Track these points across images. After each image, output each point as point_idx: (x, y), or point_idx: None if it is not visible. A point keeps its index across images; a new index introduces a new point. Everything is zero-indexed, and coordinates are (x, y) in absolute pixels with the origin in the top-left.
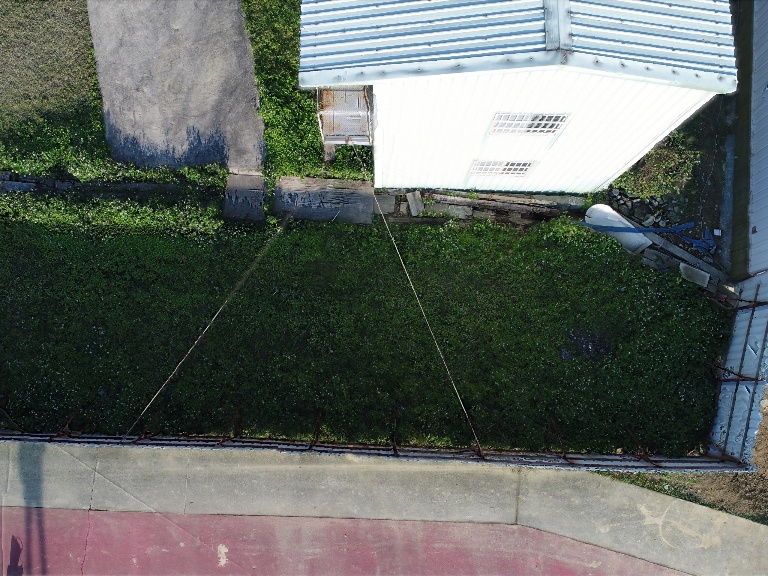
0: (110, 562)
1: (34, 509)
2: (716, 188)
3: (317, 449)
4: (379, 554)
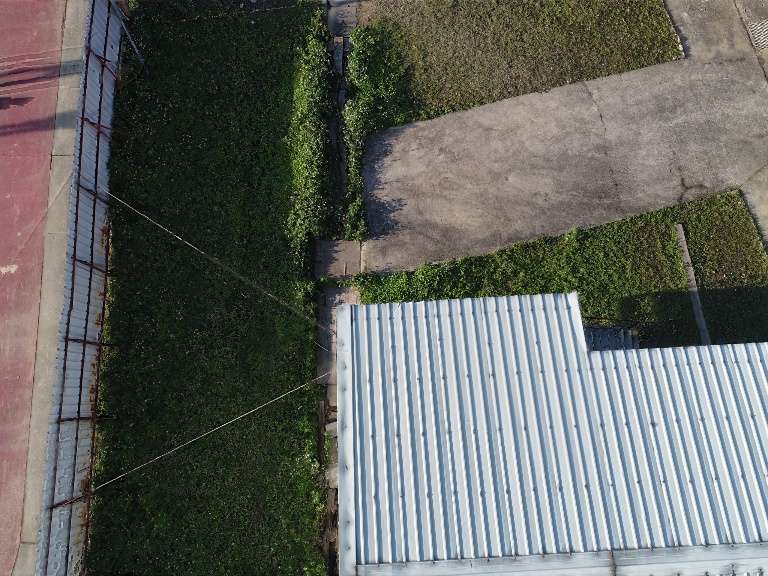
0: (8, 177)
1: (55, 111)
2: None
3: (69, 346)
4: (1, 409)
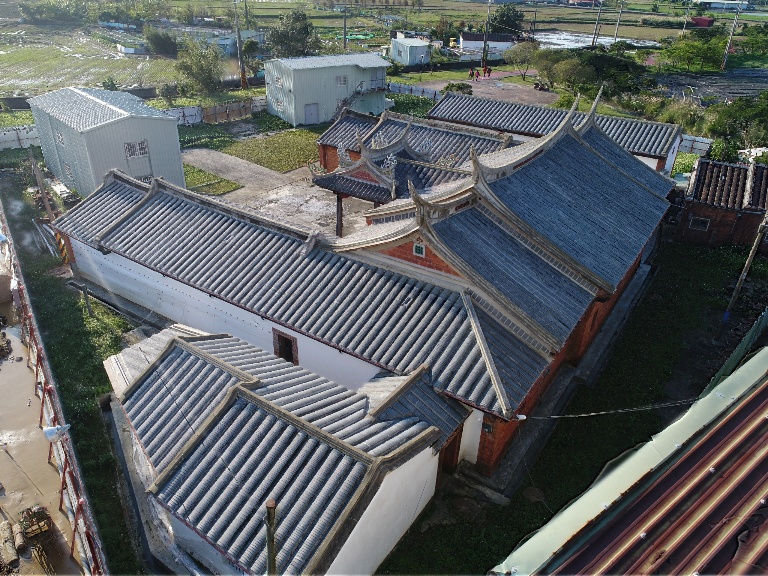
0: None
1: None
2: (3, 183)
3: None
4: None
